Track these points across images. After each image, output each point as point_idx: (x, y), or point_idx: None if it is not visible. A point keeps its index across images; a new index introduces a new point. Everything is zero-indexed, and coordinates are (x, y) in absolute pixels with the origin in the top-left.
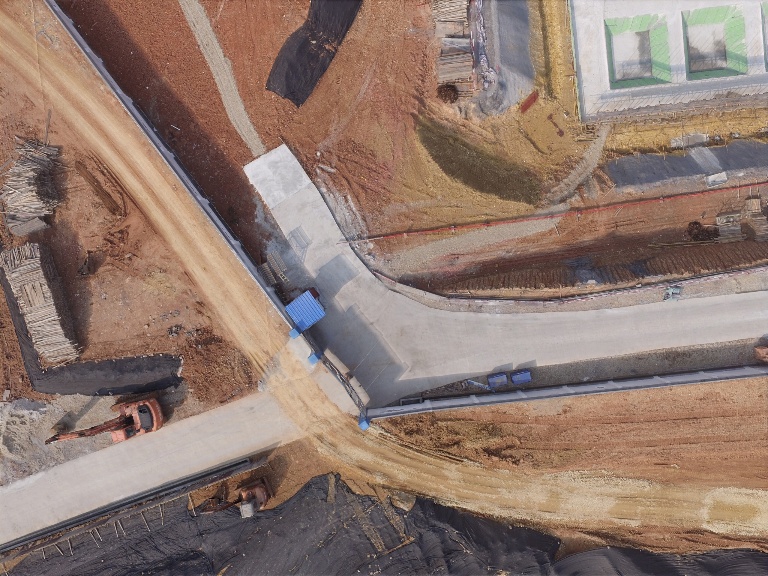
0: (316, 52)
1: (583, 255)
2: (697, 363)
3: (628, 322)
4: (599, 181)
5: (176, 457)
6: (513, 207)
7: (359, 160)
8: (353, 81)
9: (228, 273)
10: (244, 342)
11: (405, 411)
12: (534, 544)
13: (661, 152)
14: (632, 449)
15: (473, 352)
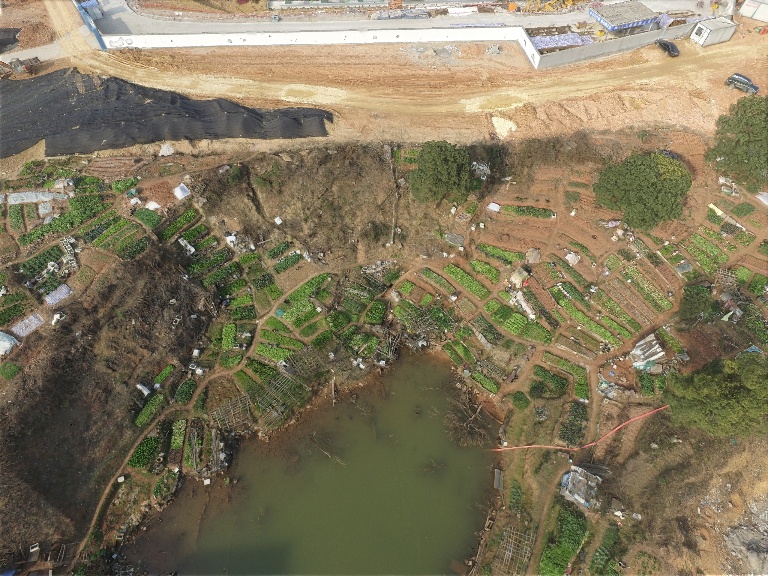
0: None
1: None
2: None
3: (252, 26)
4: None
5: None
6: None
7: None
8: None
9: None
10: (57, 27)
11: None
12: None
13: None
14: None
15: None
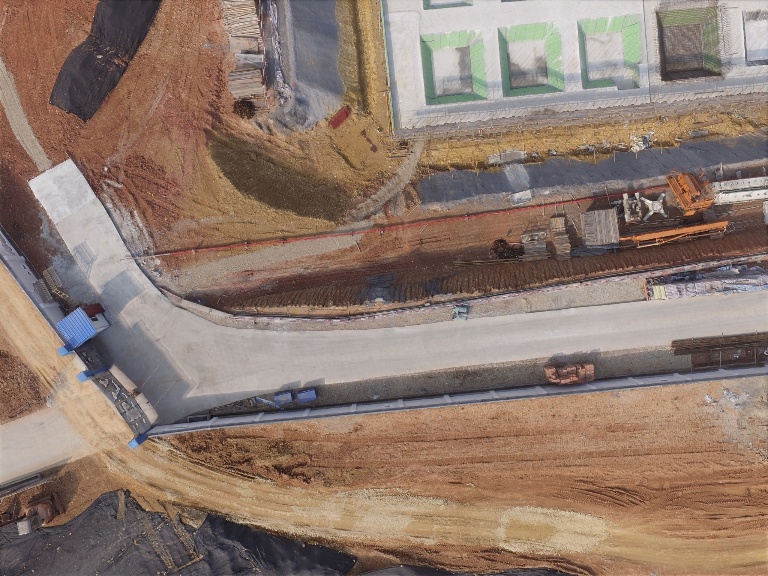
0: (104, 67)
1: (386, 272)
2: (488, 382)
3: (417, 341)
4: (407, 198)
5: None
6: (312, 223)
7: (147, 176)
8: (145, 96)
9: (13, 288)
10: (30, 357)
11: (183, 429)
12: (325, 562)
13: (476, 169)
14: (425, 468)
15: (261, 369)
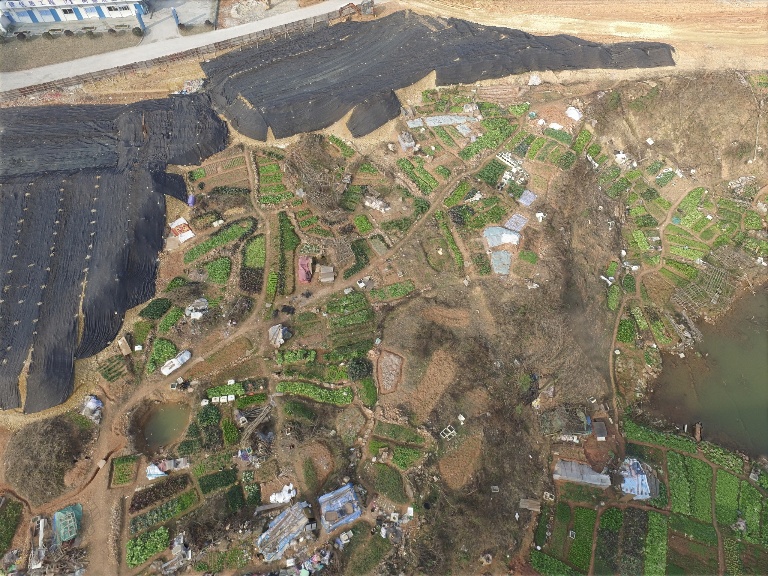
0: None
1: None
2: None
3: None
4: None
5: (325, 12)
6: None
7: None
8: None
9: None
10: None
11: None
12: None
13: None
14: None
15: None
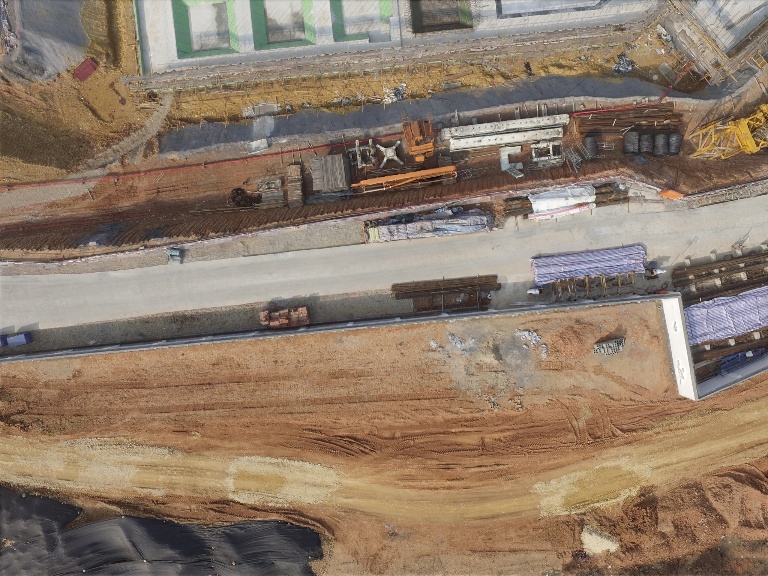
0: None
1: (121, 220)
2: (207, 327)
3: (132, 285)
4: (147, 148)
5: None
6: (41, 171)
7: None
8: None
9: None
10: None
11: None
12: (43, 513)
13: (227, 121)
14: (145, 415)
15: None
